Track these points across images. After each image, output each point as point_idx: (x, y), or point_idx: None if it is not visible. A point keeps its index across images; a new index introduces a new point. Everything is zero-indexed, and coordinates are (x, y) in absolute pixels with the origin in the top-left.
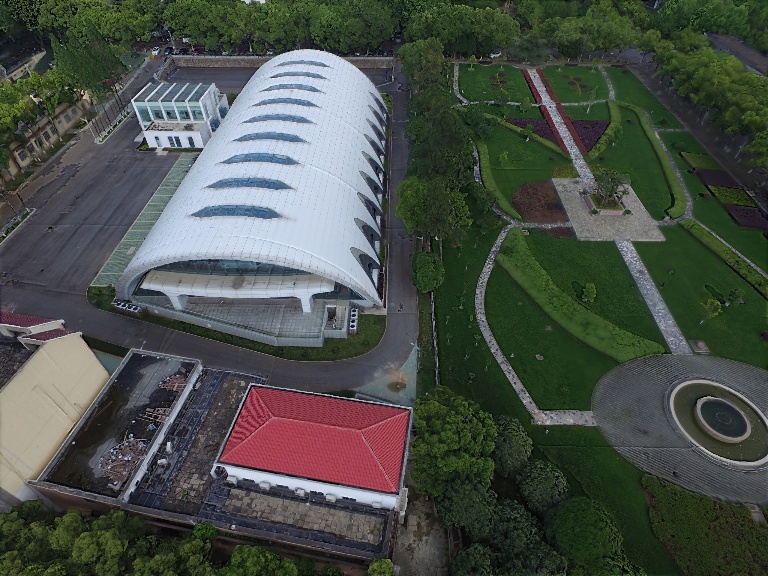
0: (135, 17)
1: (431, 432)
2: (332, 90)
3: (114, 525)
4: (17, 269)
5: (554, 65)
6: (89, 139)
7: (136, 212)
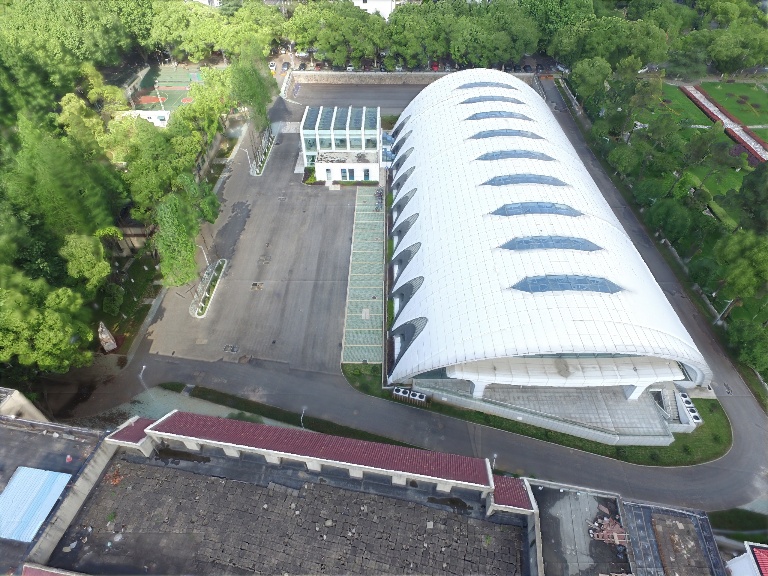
0: (254, 30)
1: None
2: (539, 117)
3: None
4: (243, 341)
5: (709, 81)
6: (243, 170)
7: (344, 263)
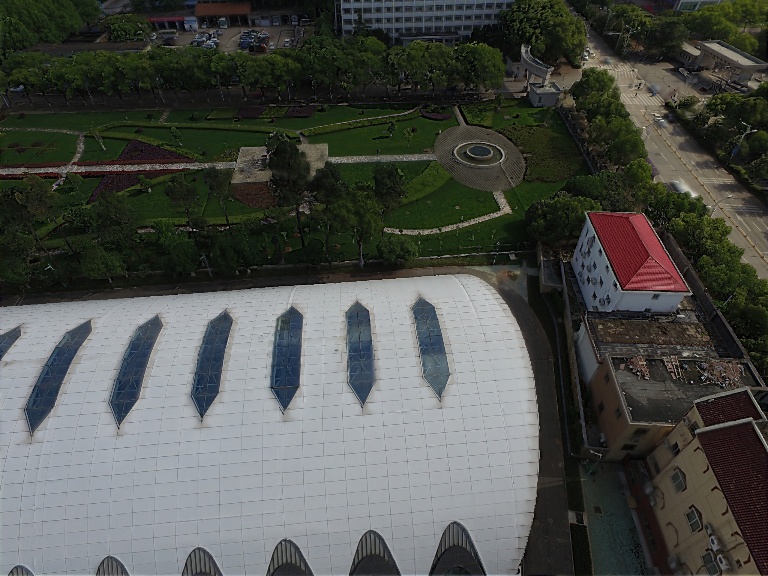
0: None
1: (591, 209)
2: (4, 320)
3: (763, 353)
4: None
5: None
6: None
7: None
